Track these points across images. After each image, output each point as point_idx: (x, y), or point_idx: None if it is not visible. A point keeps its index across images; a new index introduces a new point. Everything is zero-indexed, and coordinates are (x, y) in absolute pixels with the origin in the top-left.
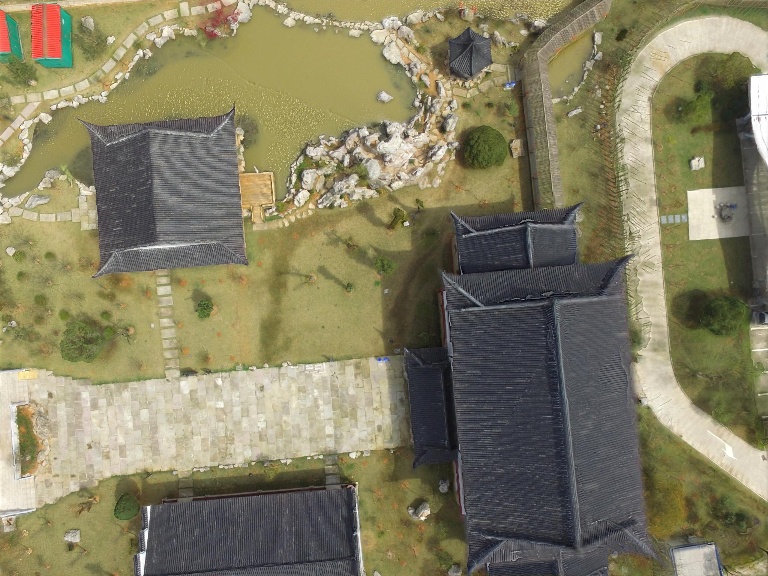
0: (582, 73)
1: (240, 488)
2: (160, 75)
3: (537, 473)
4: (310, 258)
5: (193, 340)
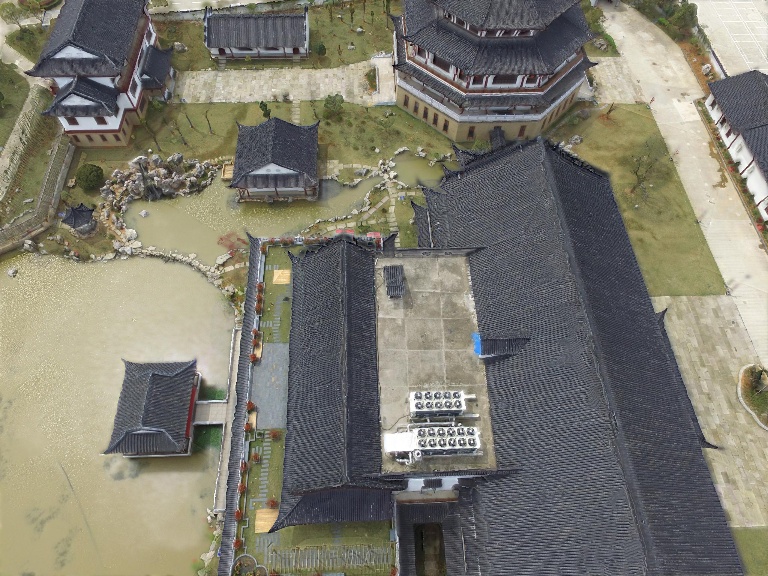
0: None
1: (269, 61)
2: None
3: (103, 3)
4: (210, 142)
5: (283, 113)
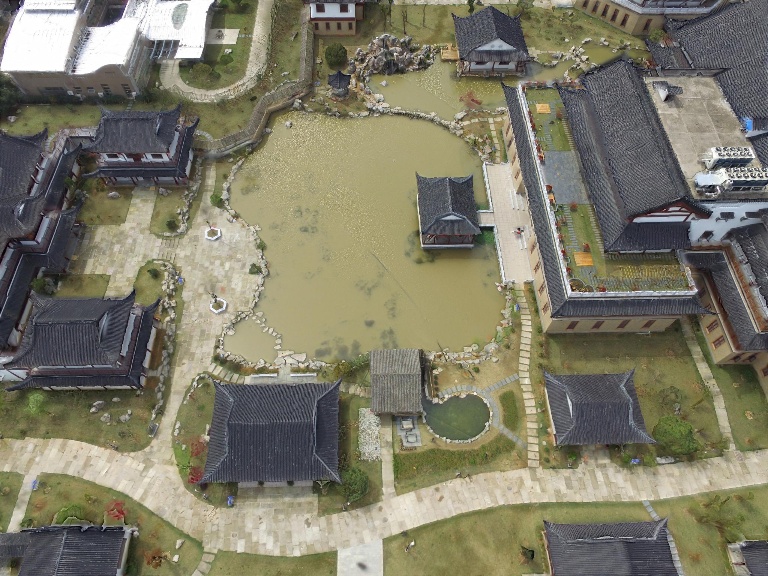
0: None
1: None
2: None
3: None
4: (424, 33)
5: None
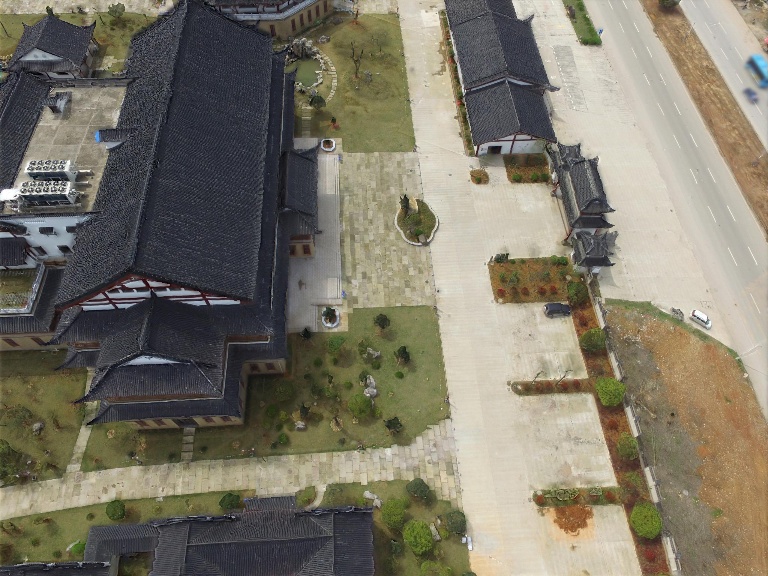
0: None
1: None
2: None
3: None
4: (6, 43)
5: (76, 21)
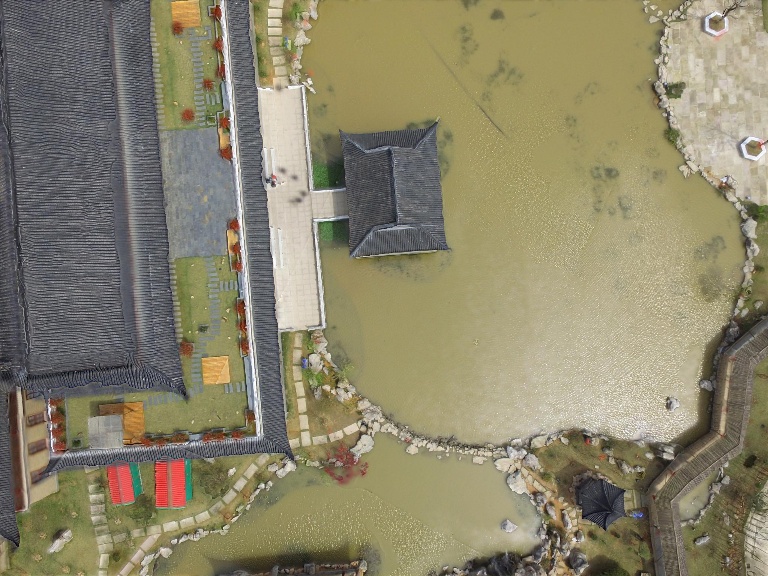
0: (708, 494)
1: None
2: (281, 503)
3: None
4: None
5: None
